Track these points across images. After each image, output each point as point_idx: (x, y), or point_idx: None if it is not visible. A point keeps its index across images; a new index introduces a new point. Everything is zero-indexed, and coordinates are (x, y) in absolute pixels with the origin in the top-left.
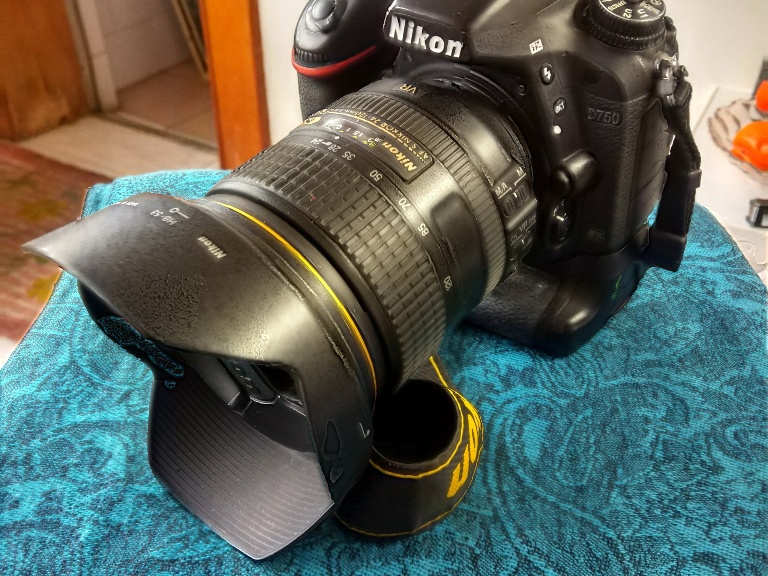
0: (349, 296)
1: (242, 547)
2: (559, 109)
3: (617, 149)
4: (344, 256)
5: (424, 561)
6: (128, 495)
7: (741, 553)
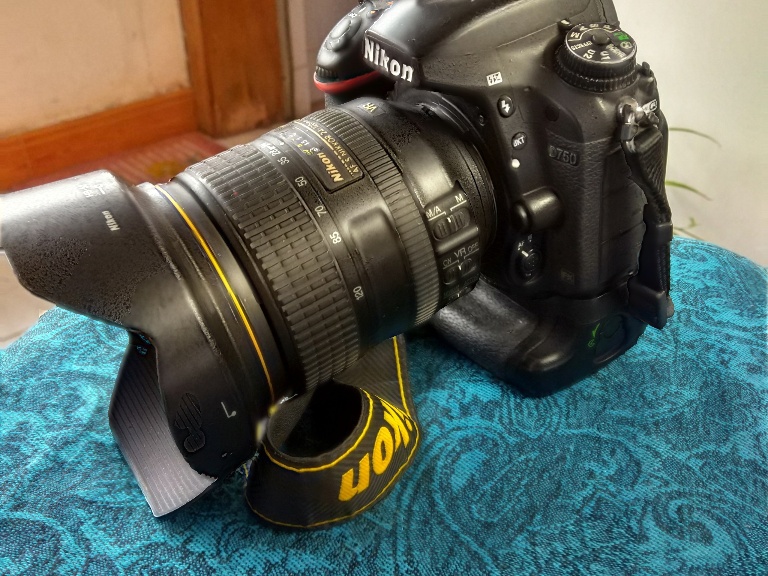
0: (244, 286)
1: (152, 504)
2: (518, 143)
3: (577, 190)
4: (245, 249)
5: (307, 555)
6: (82, 439)
7: None
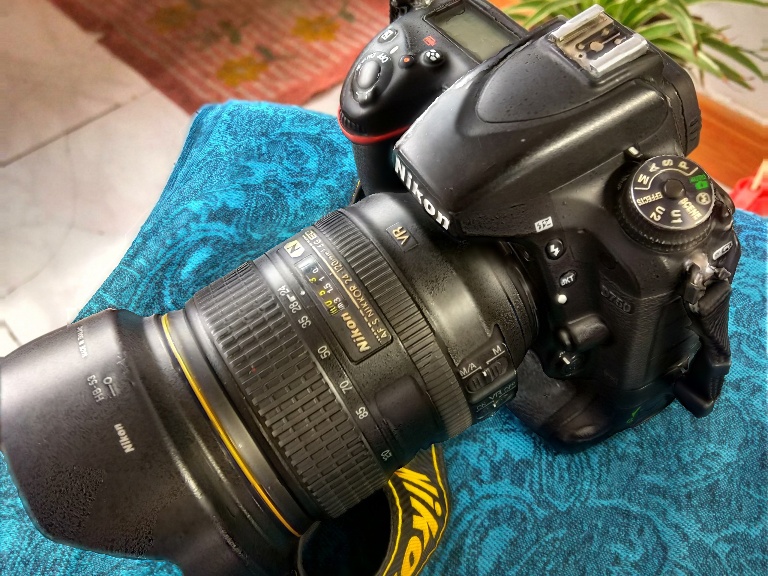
0: (267, 473)
1: None
2: (566, 282)
3: (628, 330)
4: (266, 439)
5: None
6: None
7: None
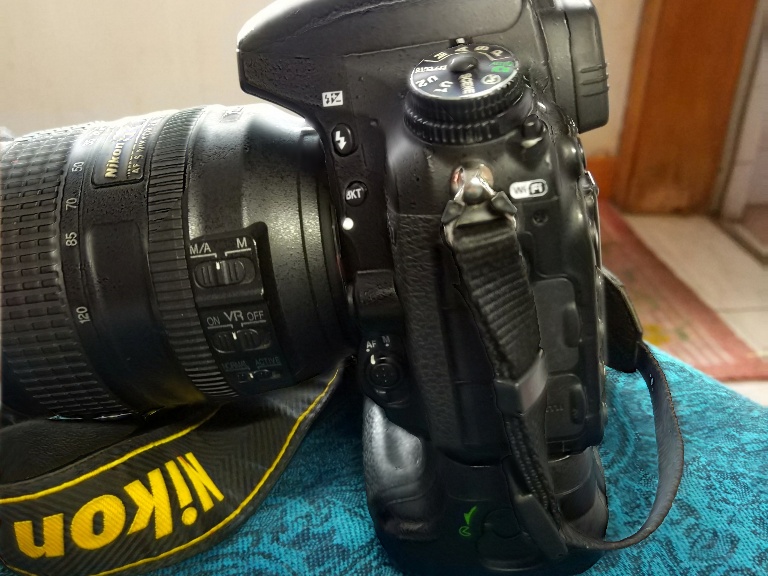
0: None
1: None
2: (353, 196)
3: None
4: None
5: None
6: None
7: None
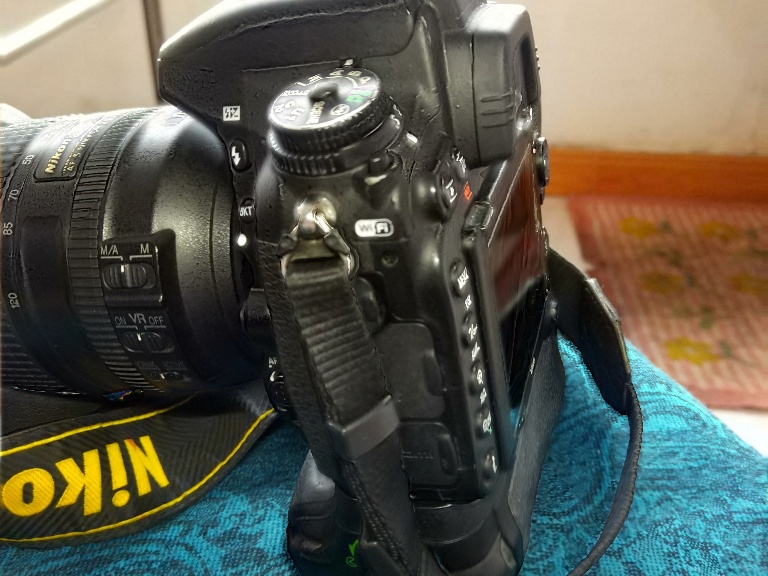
0: None
1: None
2: (245, 212)
3: None
4: None
5: None
6: None
7: None
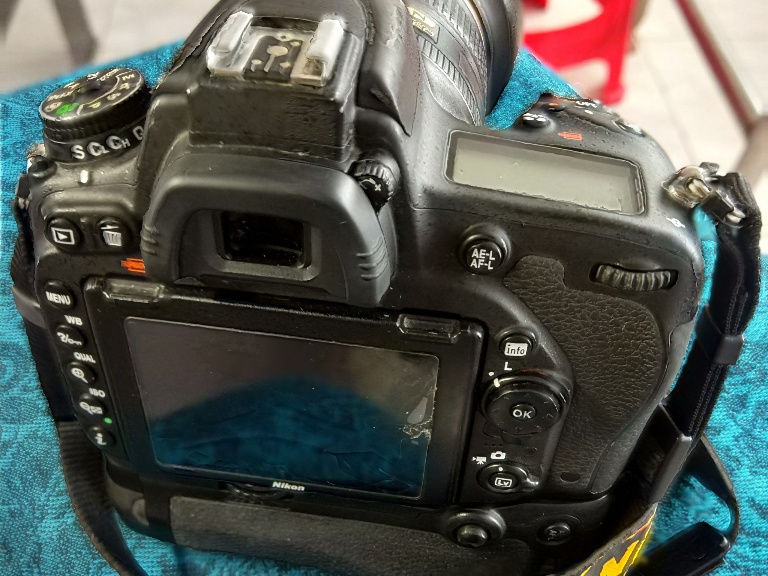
0: None
1: None
2: None
3: None
4: None
5: None
6: None
7: (8, 257)
